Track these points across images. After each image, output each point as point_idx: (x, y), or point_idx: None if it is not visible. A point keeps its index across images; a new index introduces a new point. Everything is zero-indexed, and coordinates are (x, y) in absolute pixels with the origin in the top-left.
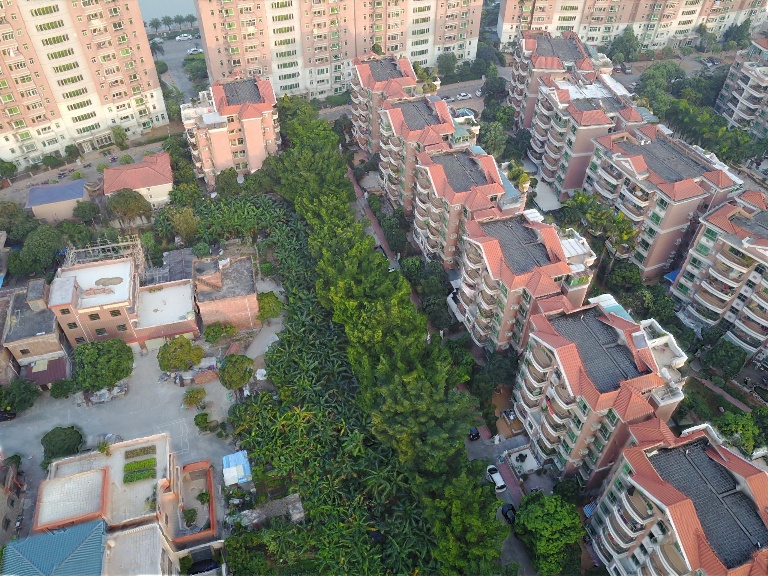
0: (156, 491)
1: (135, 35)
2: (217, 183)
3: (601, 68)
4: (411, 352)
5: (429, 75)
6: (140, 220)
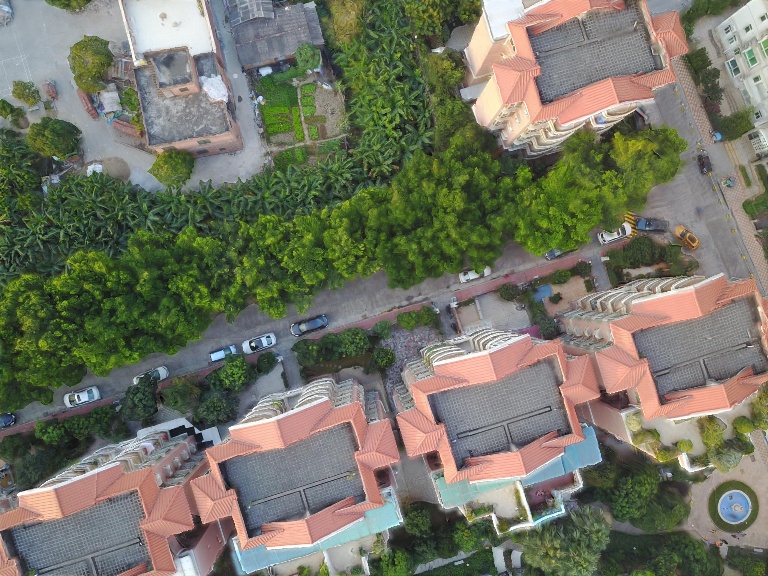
0: None
1: None
2: (442, 52)
3: None
4: None
5: (719, 449)
6: None
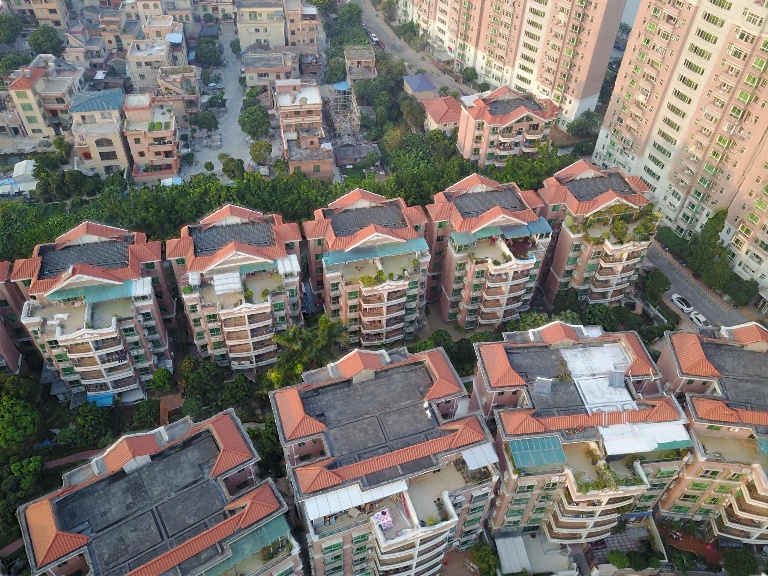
0: (138, 131)
1: (586, 45)
2: None
3: (760, 465)
4: (176, 205)
5: None
6: (415, 131)
